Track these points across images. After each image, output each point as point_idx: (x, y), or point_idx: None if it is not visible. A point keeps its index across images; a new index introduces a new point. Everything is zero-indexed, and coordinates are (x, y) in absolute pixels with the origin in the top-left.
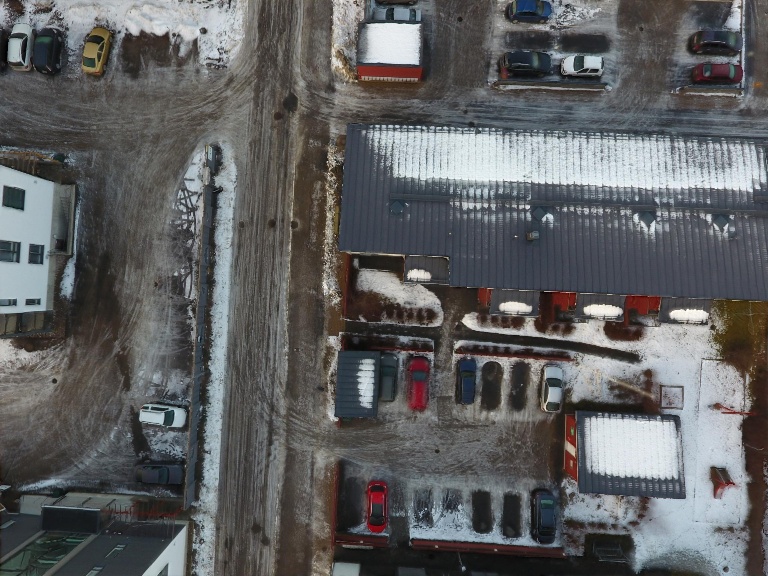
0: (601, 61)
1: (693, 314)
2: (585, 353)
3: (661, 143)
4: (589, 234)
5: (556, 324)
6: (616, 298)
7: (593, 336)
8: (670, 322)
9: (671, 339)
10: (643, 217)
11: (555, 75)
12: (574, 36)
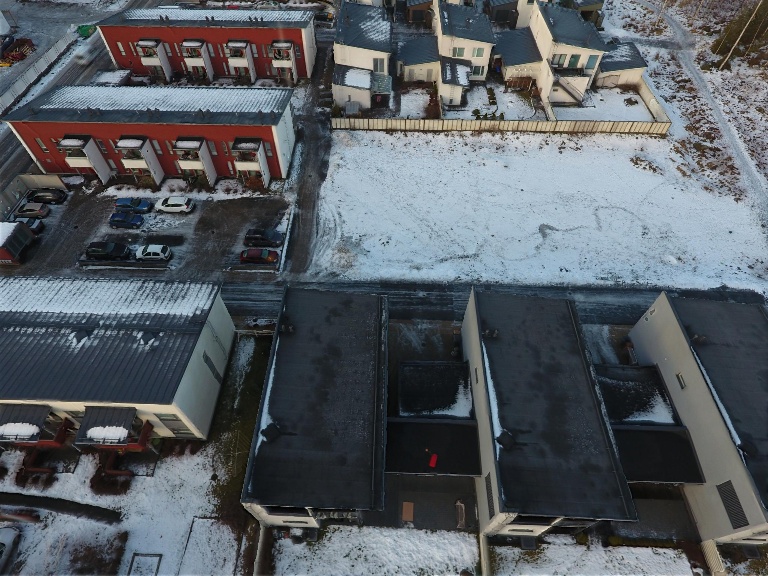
0: (162, 247)
1: (111, 431)
2: (59, 512)
3: (134, 284)
4: (18, 348)
5: (37, 475)
6: (37, 416)
7: (76, 490)
8: (86, 442)
9: (164, 492)
10: (77, 334)
11: (132, 260)
12: (158, 236)
